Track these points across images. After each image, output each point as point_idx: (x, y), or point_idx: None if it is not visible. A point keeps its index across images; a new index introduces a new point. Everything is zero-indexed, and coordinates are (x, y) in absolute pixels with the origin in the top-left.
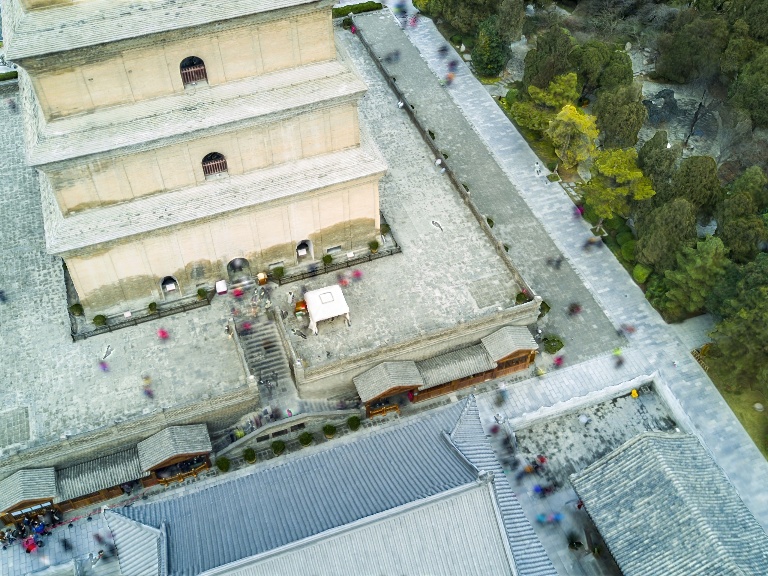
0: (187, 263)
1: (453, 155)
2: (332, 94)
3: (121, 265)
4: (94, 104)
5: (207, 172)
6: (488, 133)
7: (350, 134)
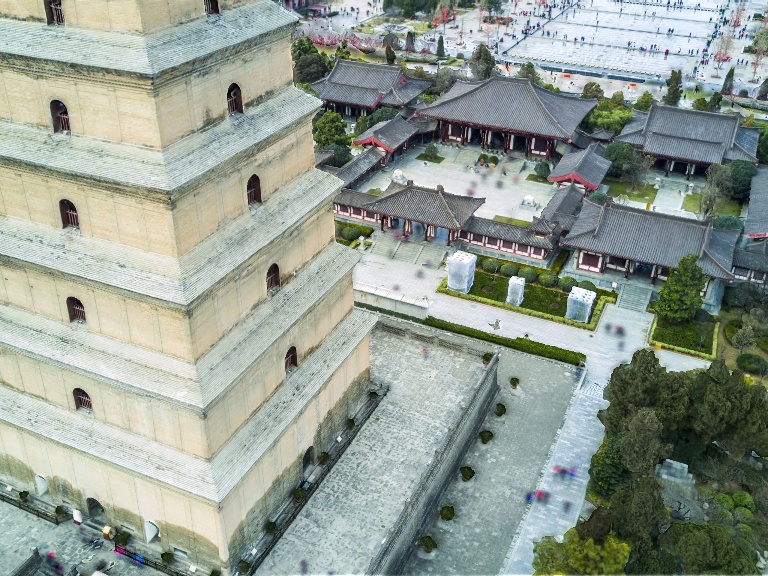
0: (55, 475)
1: (456, 550)
2: (170, 393)
3: (7, 442)
4: (9, 299)
5: (84, 404)
6: (523, 553)
7: (199, 444)
